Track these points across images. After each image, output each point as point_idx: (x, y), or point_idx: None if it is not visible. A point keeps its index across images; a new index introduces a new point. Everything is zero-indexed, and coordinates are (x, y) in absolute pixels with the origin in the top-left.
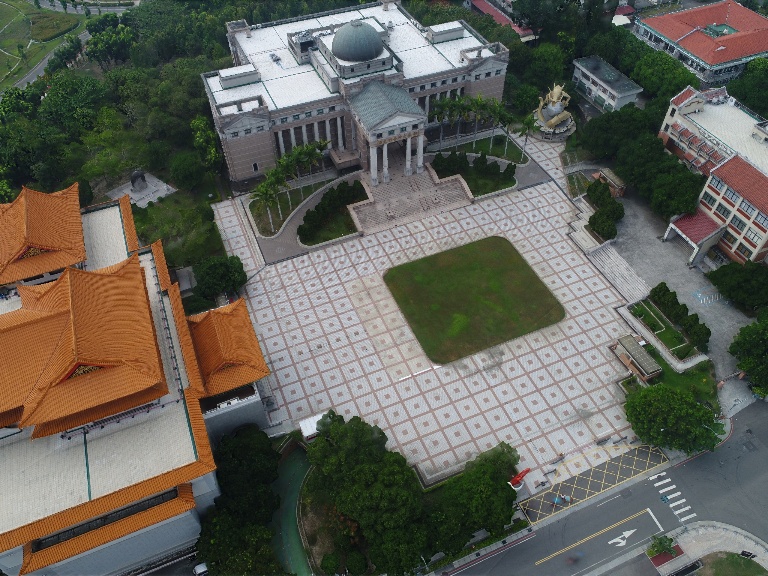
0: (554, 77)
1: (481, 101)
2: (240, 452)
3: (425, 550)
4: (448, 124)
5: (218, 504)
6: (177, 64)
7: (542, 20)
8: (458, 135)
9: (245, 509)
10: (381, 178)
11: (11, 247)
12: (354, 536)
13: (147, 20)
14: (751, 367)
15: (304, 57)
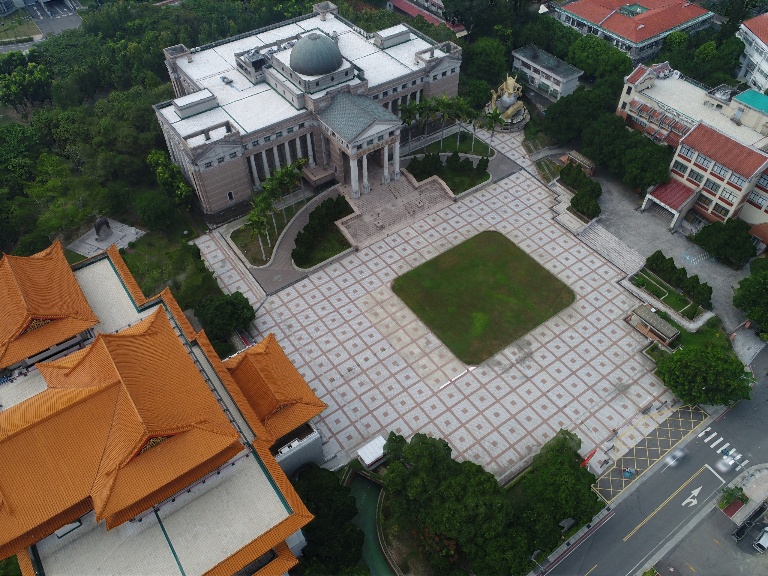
0: (498, 69)
1: (447, 101)
2: (314, 495)
3: (526, 552)
4: (410, 127)
5: (307, 554)
6: (112, 98)
7: (474, 16)
8: (425, 137)
9: (338, 553)
10: (361, 189)
11: (7, 323)
12: (452, 554)
13: (60, 55)
14: (760, 316)
15: (258, 76)
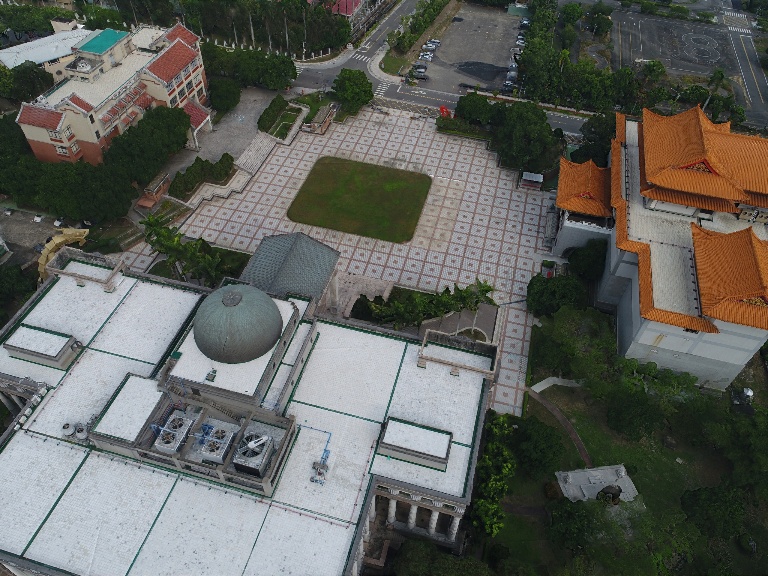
0: None
1: None
2: None
3: None
4: None
5: None
6: None
7: None
8: None
9: None
10: None
11: None
12: None
13: None
14: None
15: None
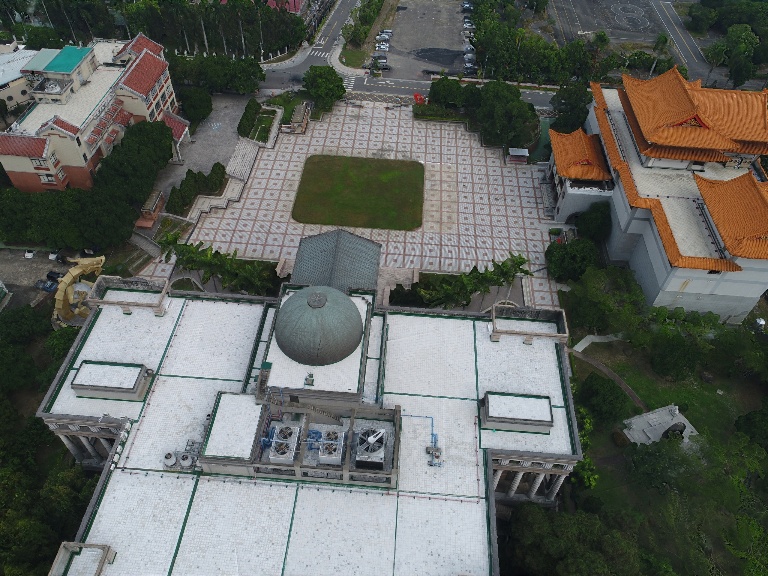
0: None
1: None
2: None
3: None
4: None
5: None
6: None
7: None
8: None
9: None
10: None
11: (767, 197)
12: None
13: None
14: None
15: None
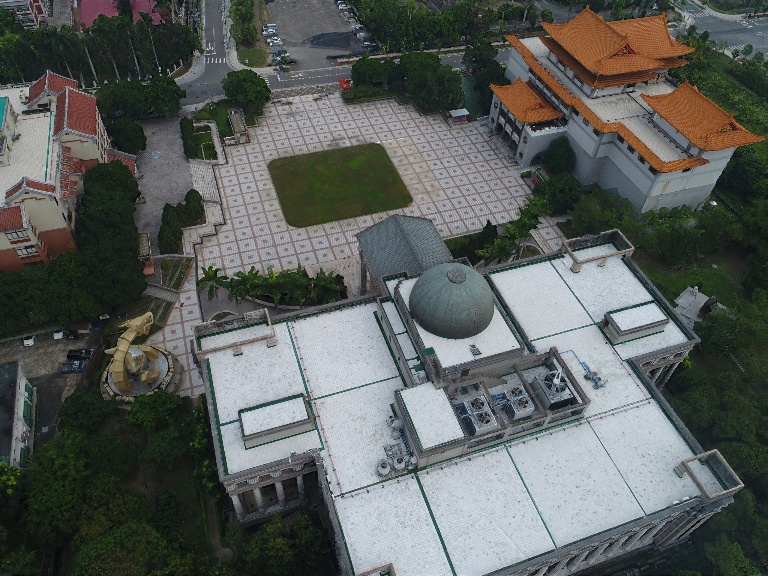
0: None
1: (271, 277)
2: None
3: None
4: None
5: None
6: None
7: None
8: None
9: None
10: None
11: None
12: None
13: None
14: None
15: None
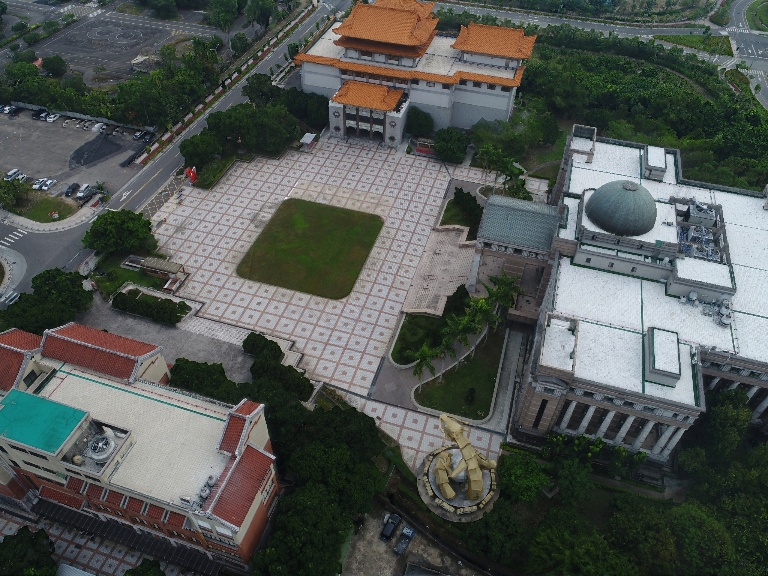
0: None
1: (480, 307)
2: None
3: None
4: None
5: None
6: None
7: None
8: None
9: None
10: (485, 261)
11: None
12: None
13: None
14: None
15: None
